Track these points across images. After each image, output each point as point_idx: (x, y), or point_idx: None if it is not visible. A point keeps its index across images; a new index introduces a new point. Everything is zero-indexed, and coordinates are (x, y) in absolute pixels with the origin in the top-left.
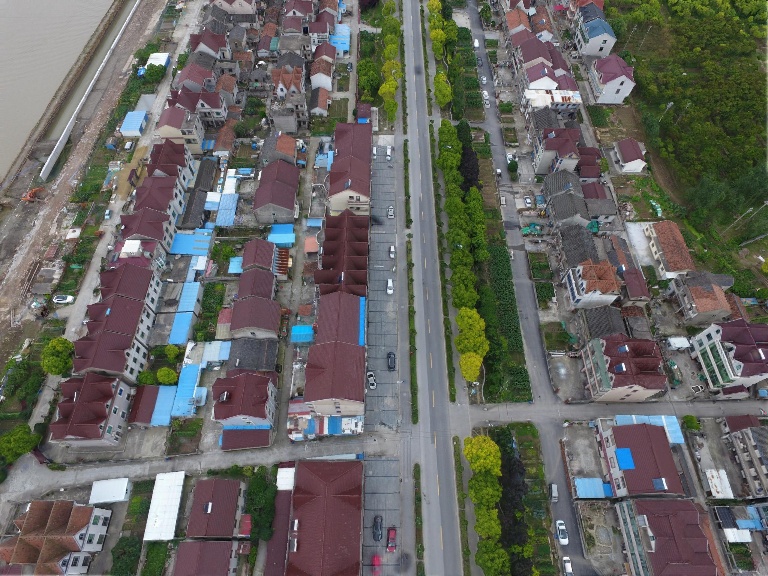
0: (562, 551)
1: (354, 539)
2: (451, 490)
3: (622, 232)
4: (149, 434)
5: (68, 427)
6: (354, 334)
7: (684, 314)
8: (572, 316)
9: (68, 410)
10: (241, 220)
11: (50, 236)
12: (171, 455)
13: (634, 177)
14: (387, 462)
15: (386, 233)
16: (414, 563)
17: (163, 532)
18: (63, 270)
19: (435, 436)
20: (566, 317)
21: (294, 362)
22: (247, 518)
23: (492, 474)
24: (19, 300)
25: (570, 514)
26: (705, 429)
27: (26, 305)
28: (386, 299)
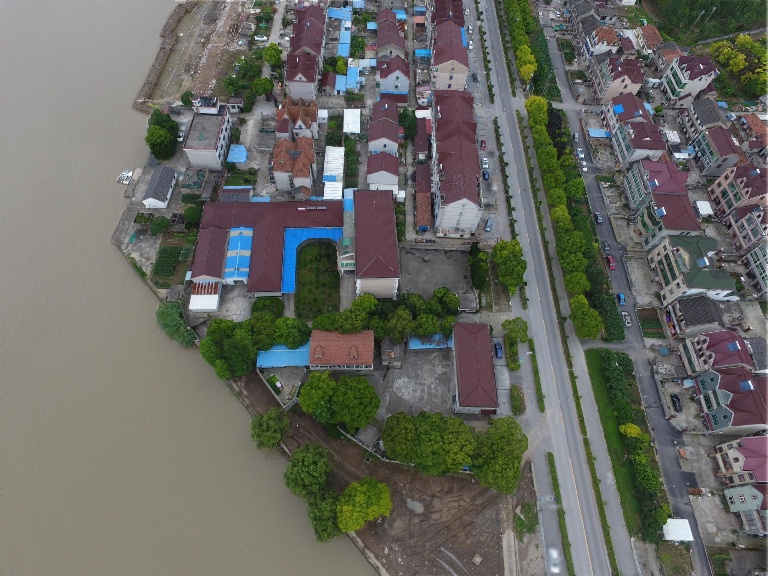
0: (580, 161)
1: (471, 117)
2: (516, 130)
3: (620, 30)
4: (332, 98)
5: (299, 69)
6: (460, 41)
7: (658, 67)
8: (587, 69)
9: (294, 67)
10: (369, 6)
11: (239, 12)
12: (349, 105)
13: (629, 8)
14: (477, 118)
15: (465, 22)
16: (497, 155)
17: (354, 130)
18: (256, 25)
19: (505, 110)
20: (583, 69)
21: (417, 69)
22: (401, 128)
23: (542, 111)
24: (229, 40)
25: (585, 148)
26: (667, 120)
27: (235, 43)
28: (468, 52)
